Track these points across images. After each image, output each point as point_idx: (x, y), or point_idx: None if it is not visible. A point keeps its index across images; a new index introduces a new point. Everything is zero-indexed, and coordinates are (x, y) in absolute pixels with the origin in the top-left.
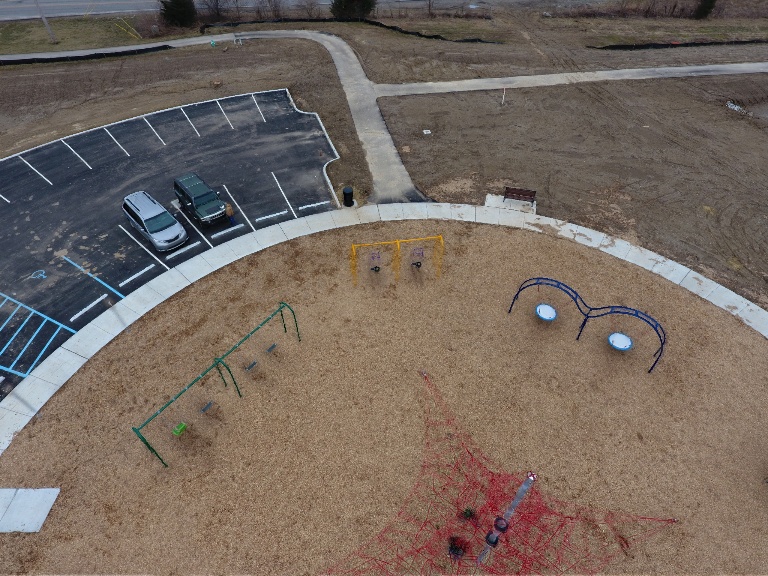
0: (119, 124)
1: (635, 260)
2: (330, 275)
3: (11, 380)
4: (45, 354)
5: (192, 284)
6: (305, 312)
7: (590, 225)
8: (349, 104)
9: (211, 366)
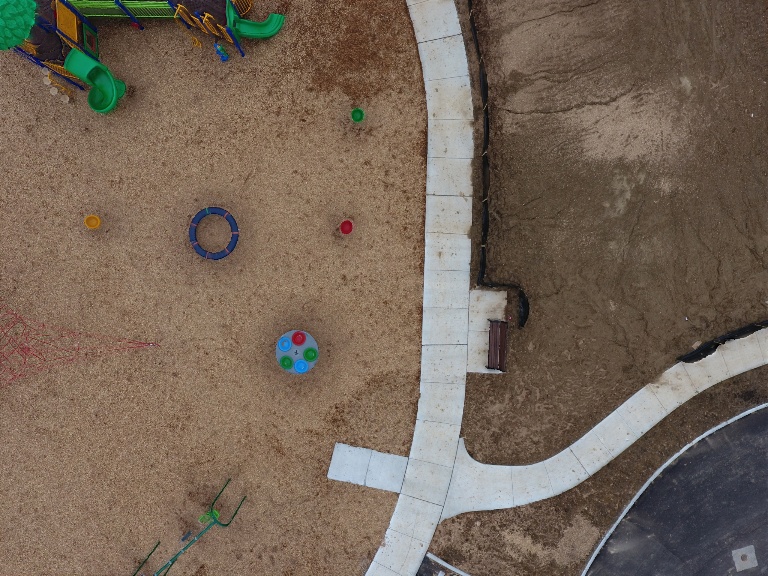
0: None
1: None
2: None
3: None
4: None
5: None
6: None
7: None
8: None
9: None
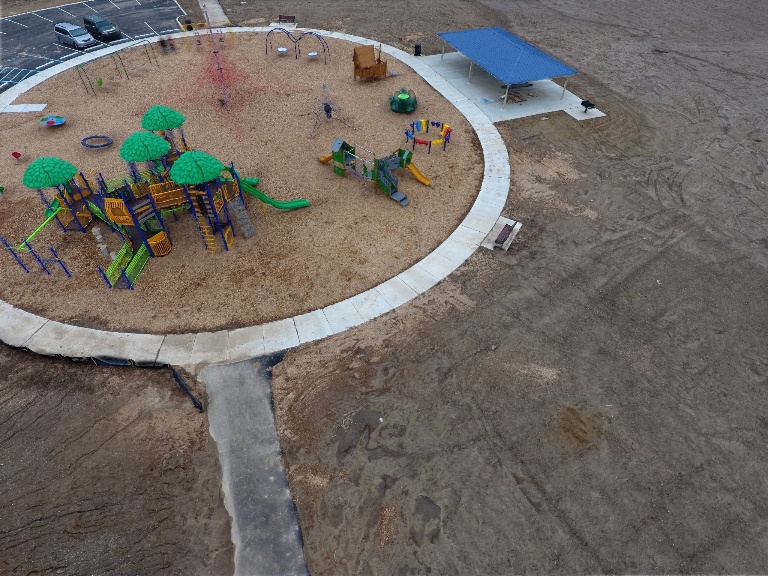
0: (41, 11)
1: (339, 37)
2: (176, 50)
3: (12, 83)
4: (26, 77)
5: None
6: (162, 60)
7: (323, 29)
8: None
9: None
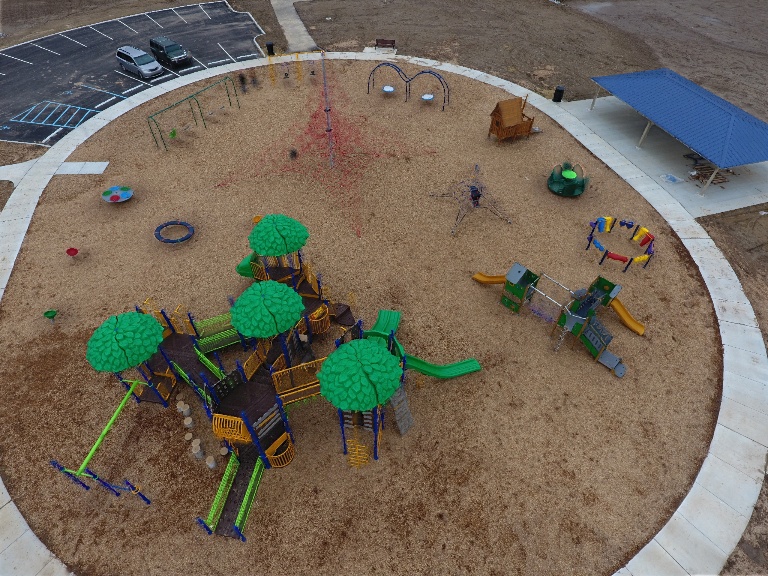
0: (100, 24)
1: (452, 70)
2: (258, 84)
3: (67, 129)
4: (84, 120)
5: (170, 91)
6: (242, 98)
7: (429, 57)
8: (273, 6)
9: (187, 98)
